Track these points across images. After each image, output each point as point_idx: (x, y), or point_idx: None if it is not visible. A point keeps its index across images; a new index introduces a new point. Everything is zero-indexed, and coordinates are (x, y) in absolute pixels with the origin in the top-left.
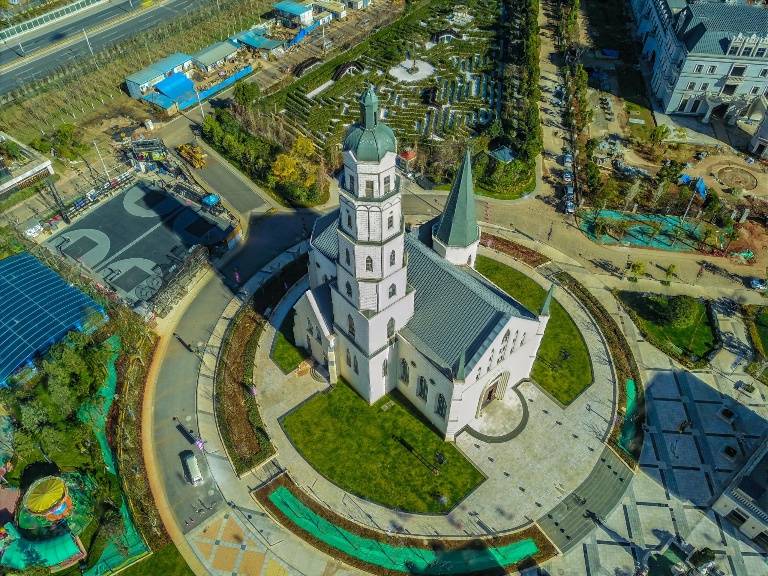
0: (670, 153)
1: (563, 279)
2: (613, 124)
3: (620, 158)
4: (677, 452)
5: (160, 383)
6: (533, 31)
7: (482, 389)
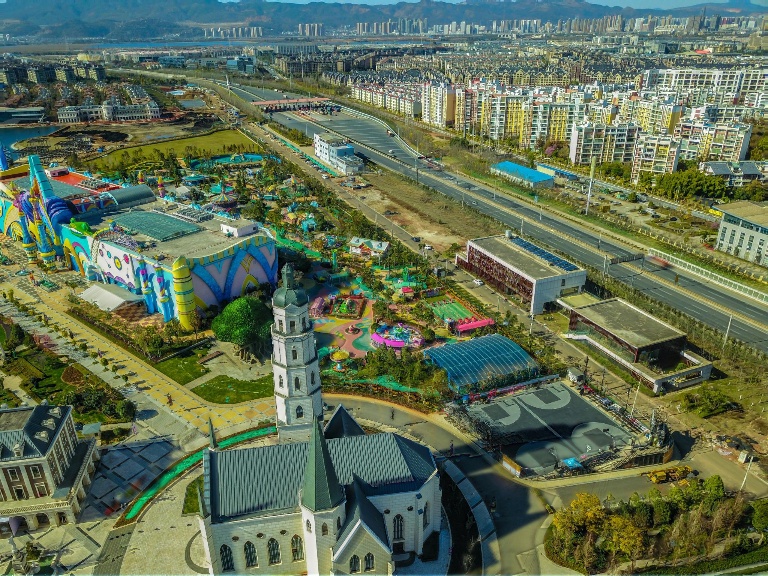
0: None
1: None
2: None
3: None
4: None
5: (390, 408)
6: None
7: None
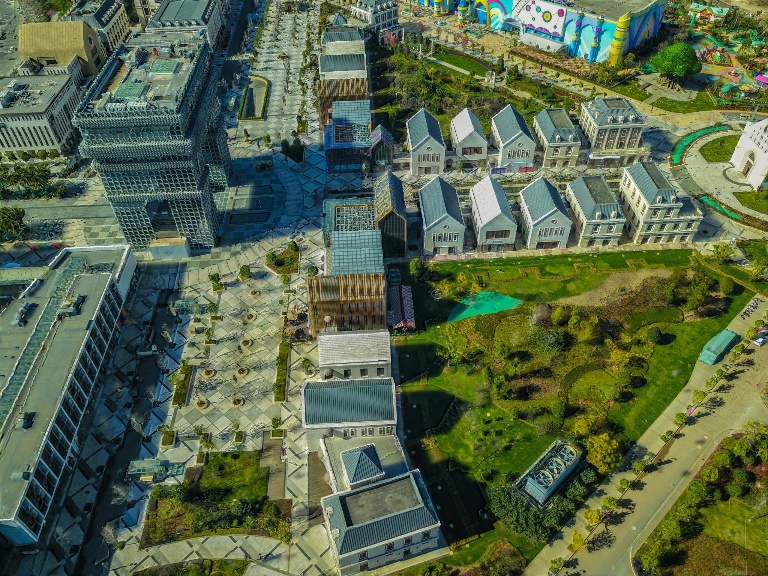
0: None
1: None
2: None
3: None
4: None
5: None
6: None
7: None
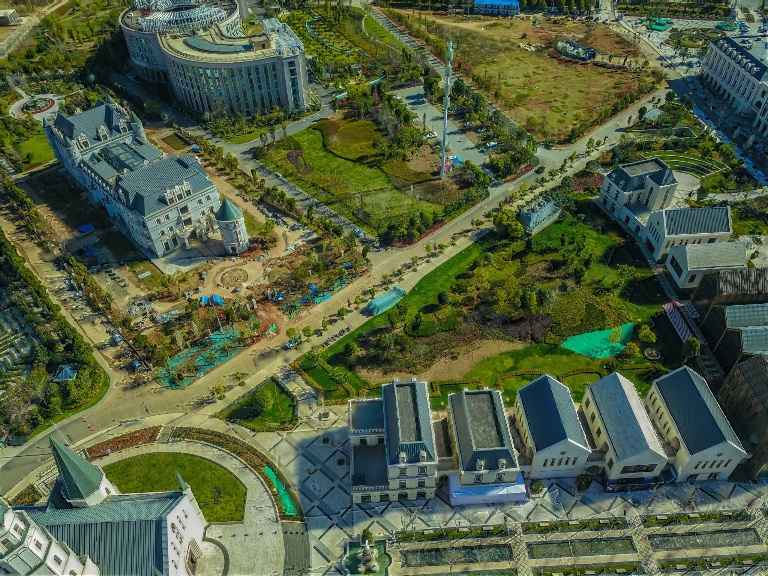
0: (183, 286)
1: (179, 434)
2: (130, 288)
3: (153, 313)
4: (318, 488)
5: None
6: (11, 251)
7: (184, 567)
